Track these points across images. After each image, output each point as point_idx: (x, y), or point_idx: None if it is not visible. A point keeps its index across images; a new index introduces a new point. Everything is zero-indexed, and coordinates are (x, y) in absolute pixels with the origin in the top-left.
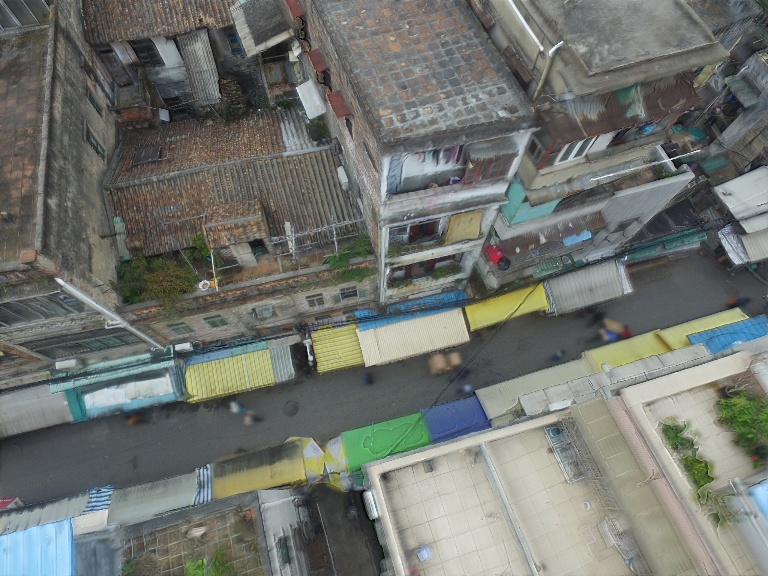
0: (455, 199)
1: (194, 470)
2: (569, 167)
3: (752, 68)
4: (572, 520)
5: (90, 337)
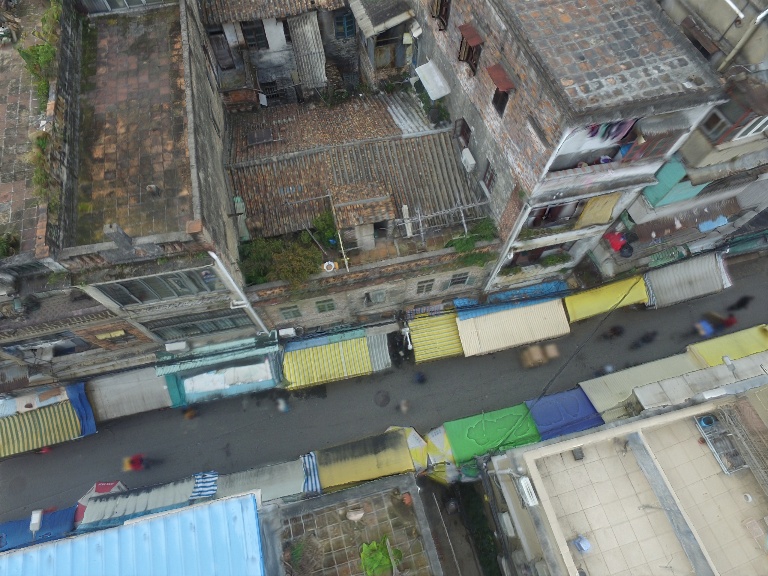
0: (607, 178)
1: None
2: (745, 143)
3: None
4: (733, 512)
5: (207, 318)
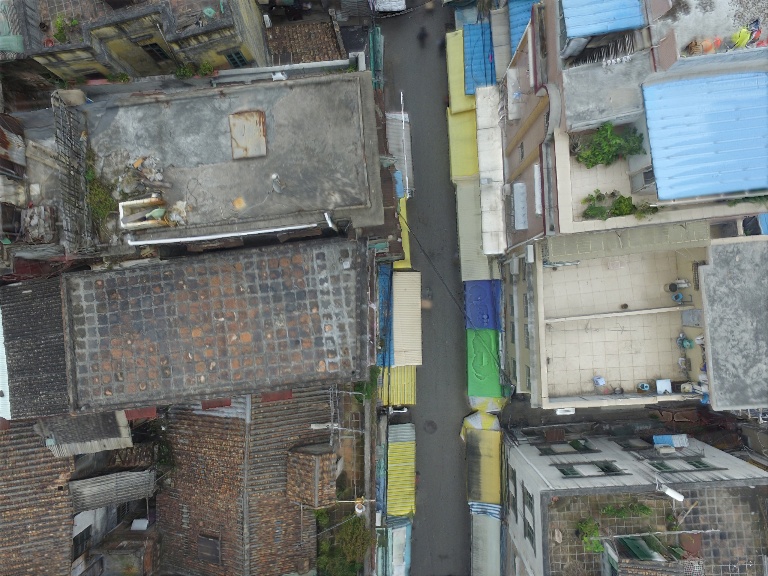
0: None
1: (471, 515)
2: None
3: None
4: (602, 270)
5: None
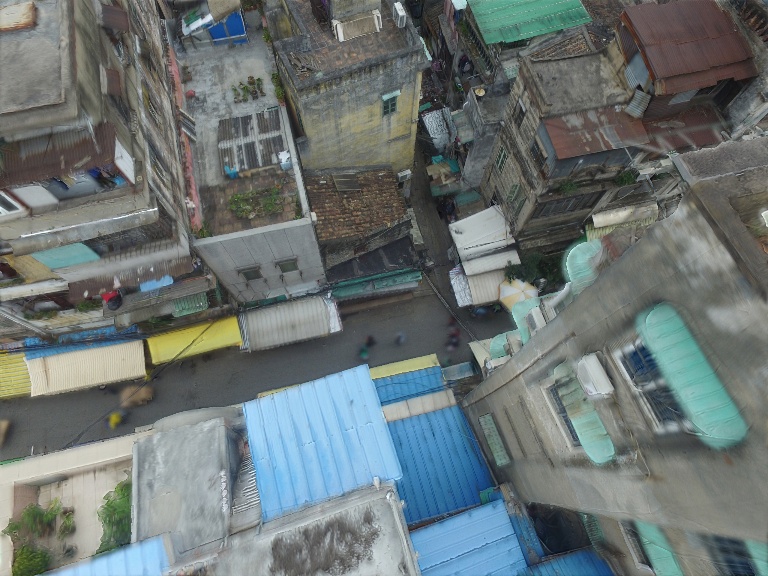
0: None
1: None
2: (13, 220)
3: (470, 104)
4: None
5: None
